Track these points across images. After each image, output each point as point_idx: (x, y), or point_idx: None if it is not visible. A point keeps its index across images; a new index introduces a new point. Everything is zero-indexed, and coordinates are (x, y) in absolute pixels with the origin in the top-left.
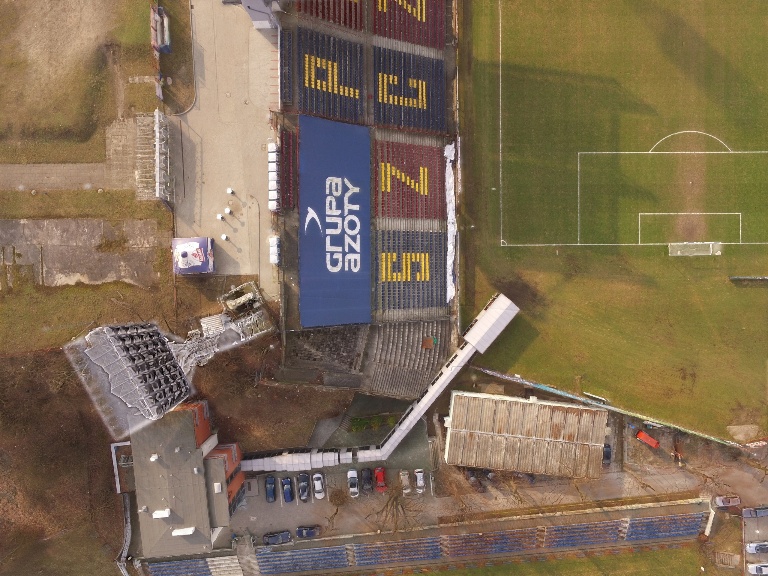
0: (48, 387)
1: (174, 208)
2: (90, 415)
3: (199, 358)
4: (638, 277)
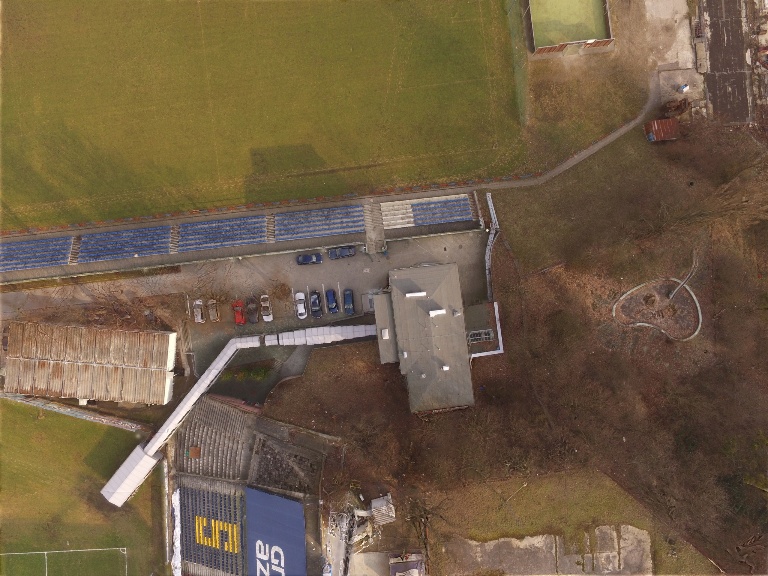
0: (549, 437)
1: None
2: (522, 384)
3: None
4: None
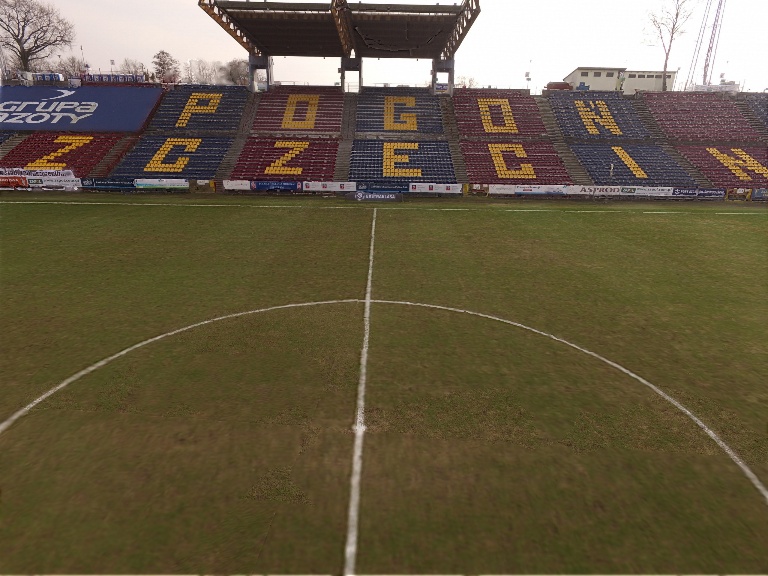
0: None
1: None
2: None
3: None
4: None
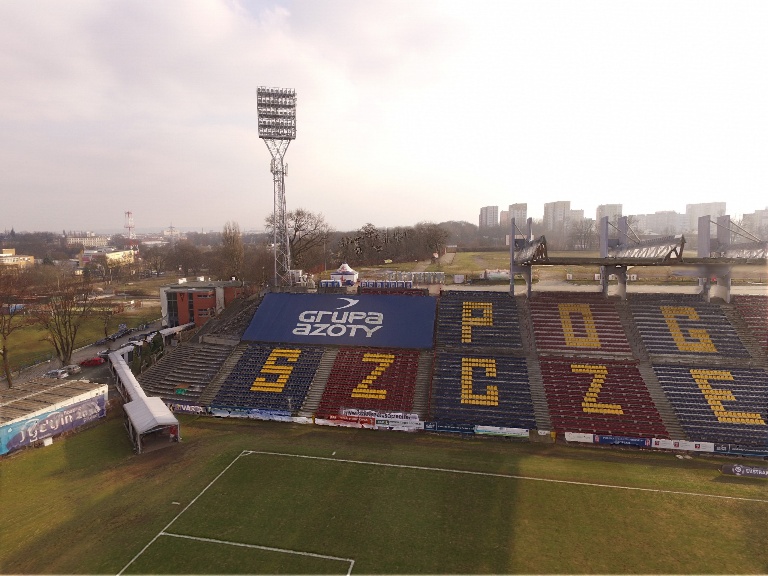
0: None
1: None
2: None
3: (273, 159)
4: None
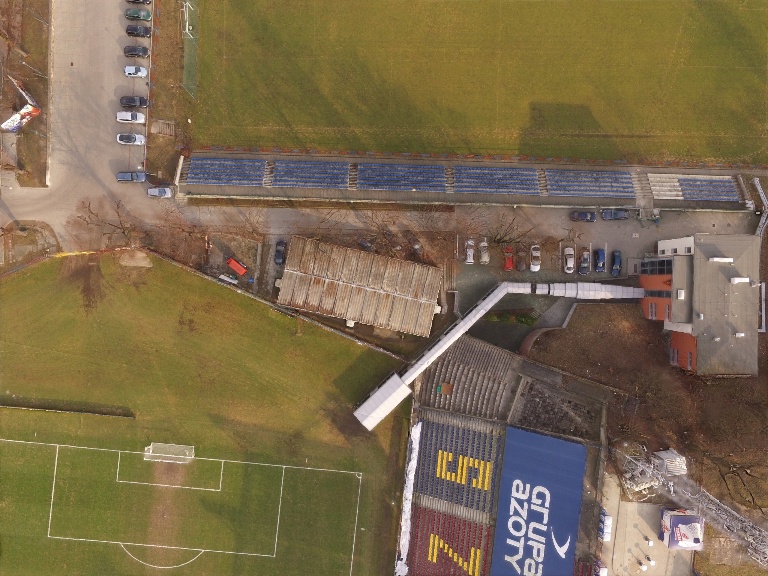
0: None
1: (692, 572)
2: None
3: None
4: (228, 428)
